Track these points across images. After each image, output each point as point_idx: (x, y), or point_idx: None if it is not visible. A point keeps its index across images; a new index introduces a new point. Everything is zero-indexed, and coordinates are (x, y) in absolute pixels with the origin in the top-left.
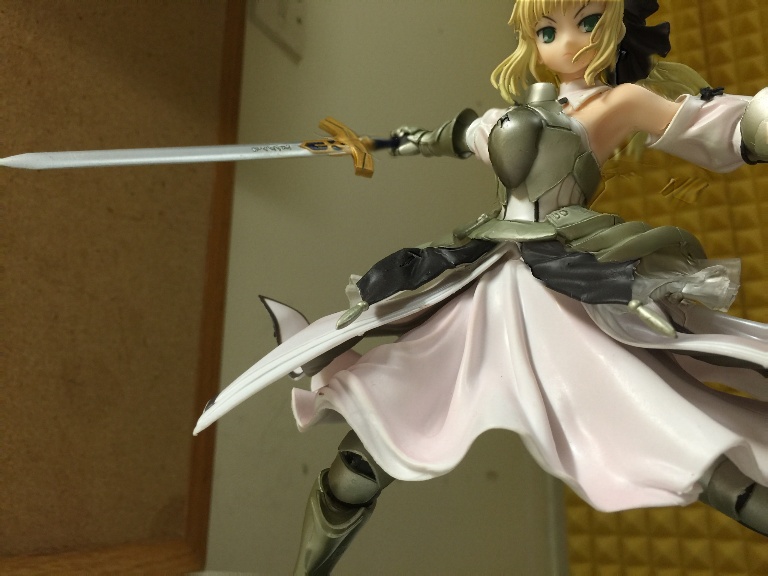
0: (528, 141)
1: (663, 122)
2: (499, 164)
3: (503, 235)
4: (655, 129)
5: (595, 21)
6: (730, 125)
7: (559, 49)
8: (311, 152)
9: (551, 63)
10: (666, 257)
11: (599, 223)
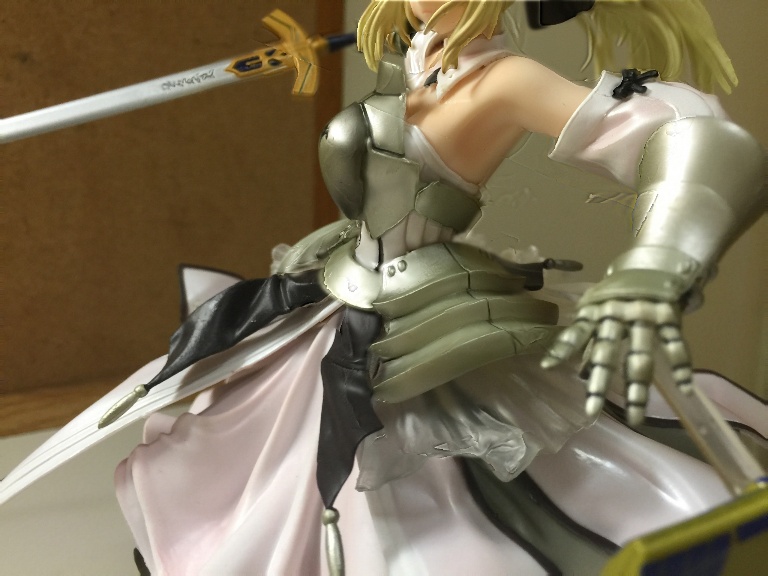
0: (348, 172)
1: (555, 130)
2: None
3: (331, 288)
4: None
5: None
6: (642, 153)
7: (416, 2)
8: (239, 76)
9: (417, 17)
10: (481, 380)
11: (439, 289)
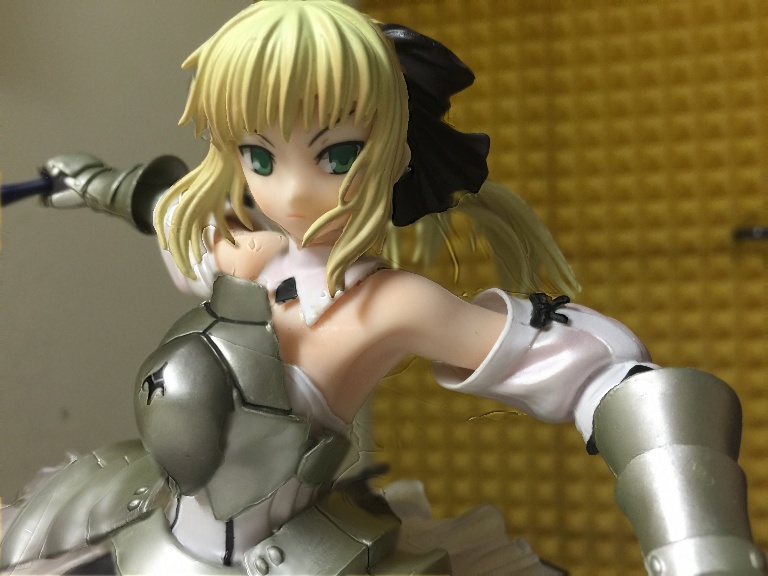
0: (203, 441)
1: (464, 360)
2: None
3: None
4: (450, 363)
5: (350, 155)
6: (575, 389)
7: (279, 202)
8: None
9: (267, 216)
10: None
11: None
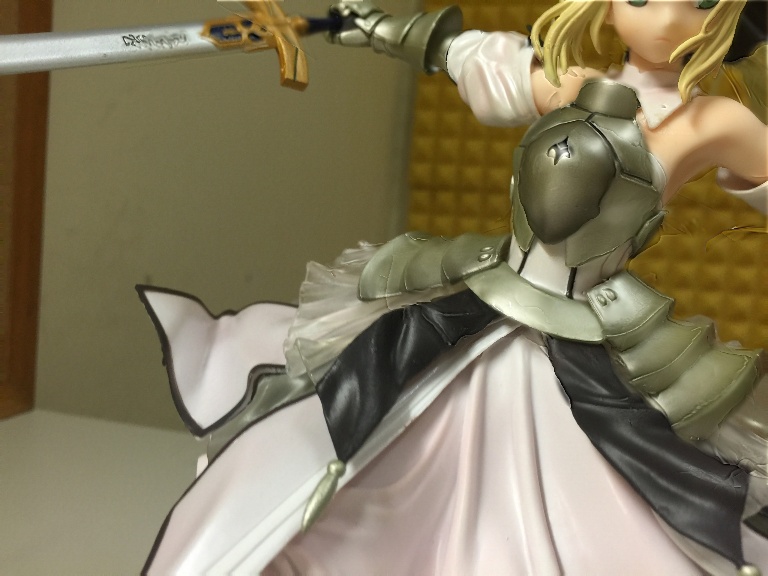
0: (591, 195)
1: (761, 170)
2: (536, 210)
3: (527, 320)
4: (745, 173)
5: None
6: None
7: (652, 27)
8: (218, 49)
9: (630, 40)
10: (743, 405)
11: None
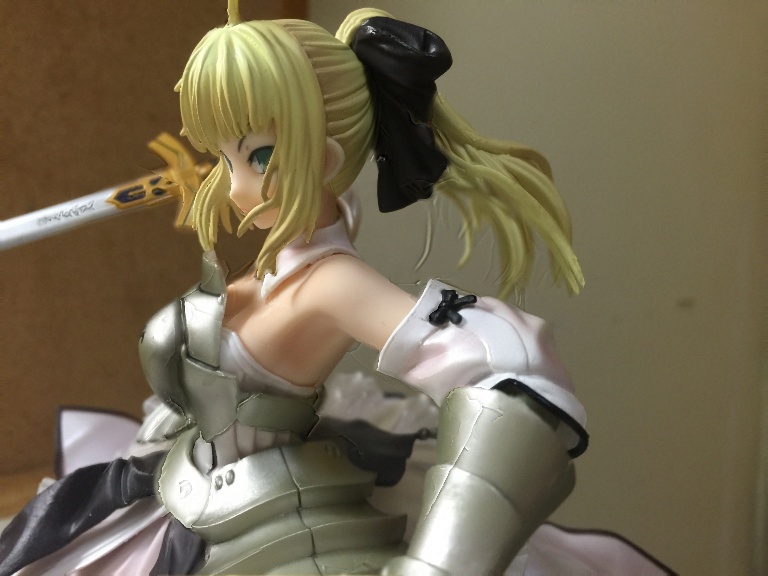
0: (164, 379)
1: None
2: None
3: (161, 493)
4: None
5: (268, 158)
6: None
7: None
8: (120, 208)
9: None
10: None
11: (265, 510)
